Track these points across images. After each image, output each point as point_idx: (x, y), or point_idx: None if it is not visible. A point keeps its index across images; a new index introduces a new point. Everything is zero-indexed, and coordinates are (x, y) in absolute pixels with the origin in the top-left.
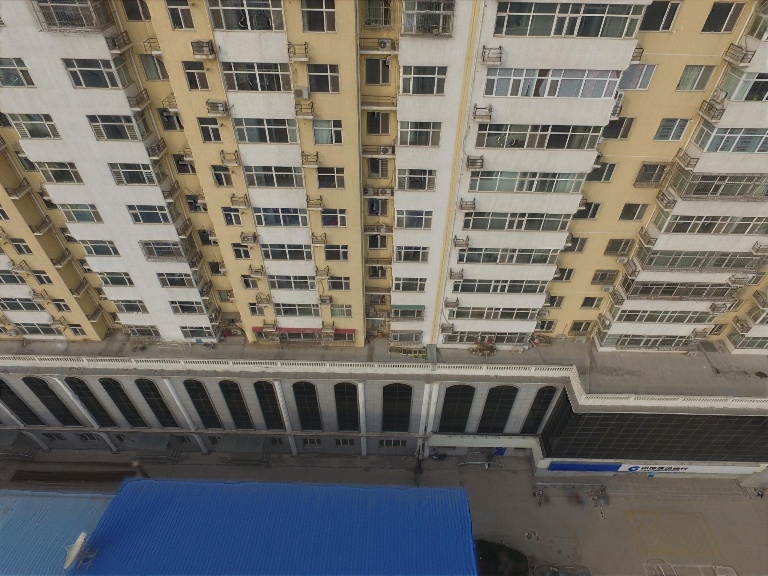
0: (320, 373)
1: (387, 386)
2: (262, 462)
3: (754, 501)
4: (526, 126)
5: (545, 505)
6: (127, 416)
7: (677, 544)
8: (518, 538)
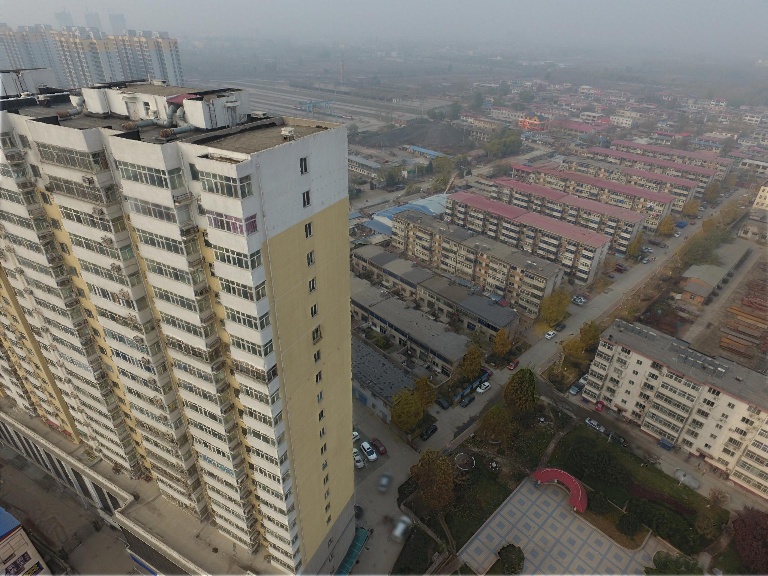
0: (50, 449)
1: None
2: (46, 488)
3: None
4: (76, 373)
5: None
6: (4, 436)
7: None
8: None
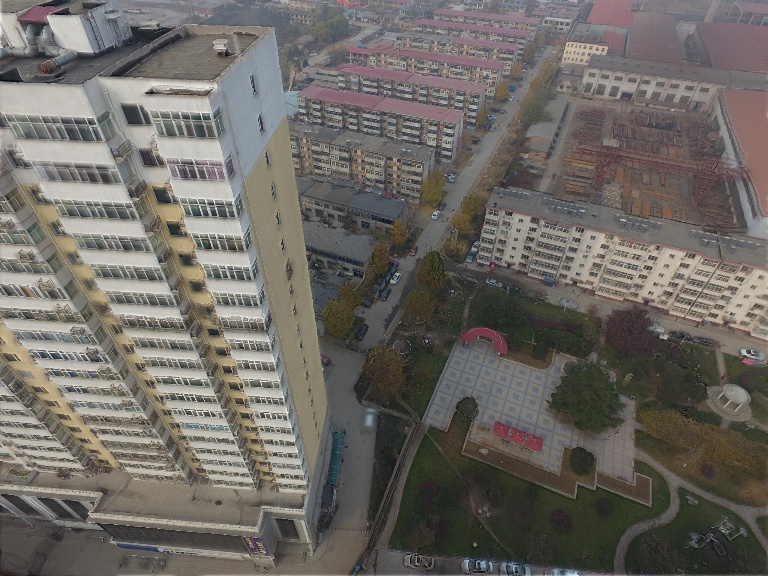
0: None
1: (2, 495)
2: None
3: (258, 575)
4: None
5: (123, 569)
6: None
7: None
8: None
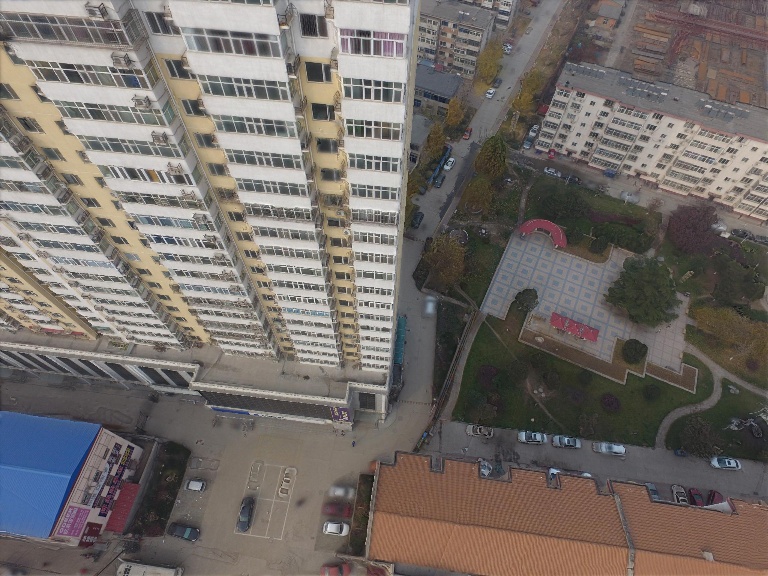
0: (66, 354)
1: (105, 363)
2: (70, 387)
3: (337, 437)
4: None
5: (217, 427)
6: None
7: (277, 455)
8: (193, 442)
